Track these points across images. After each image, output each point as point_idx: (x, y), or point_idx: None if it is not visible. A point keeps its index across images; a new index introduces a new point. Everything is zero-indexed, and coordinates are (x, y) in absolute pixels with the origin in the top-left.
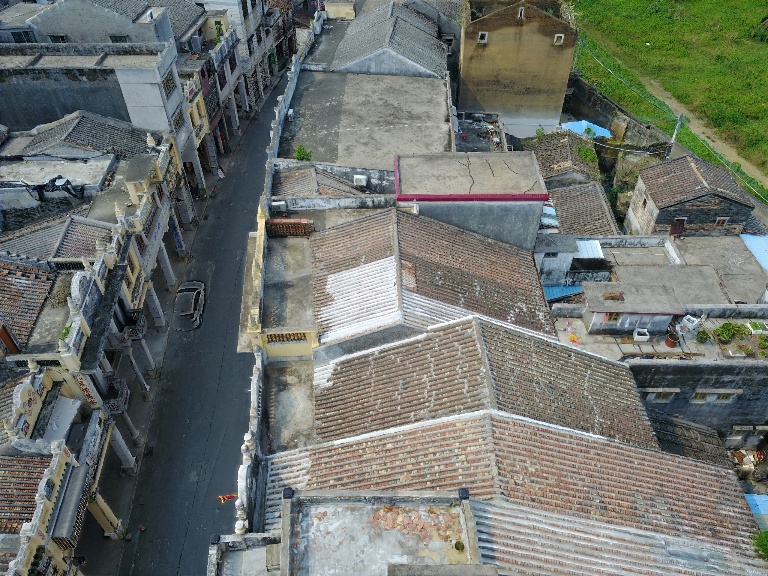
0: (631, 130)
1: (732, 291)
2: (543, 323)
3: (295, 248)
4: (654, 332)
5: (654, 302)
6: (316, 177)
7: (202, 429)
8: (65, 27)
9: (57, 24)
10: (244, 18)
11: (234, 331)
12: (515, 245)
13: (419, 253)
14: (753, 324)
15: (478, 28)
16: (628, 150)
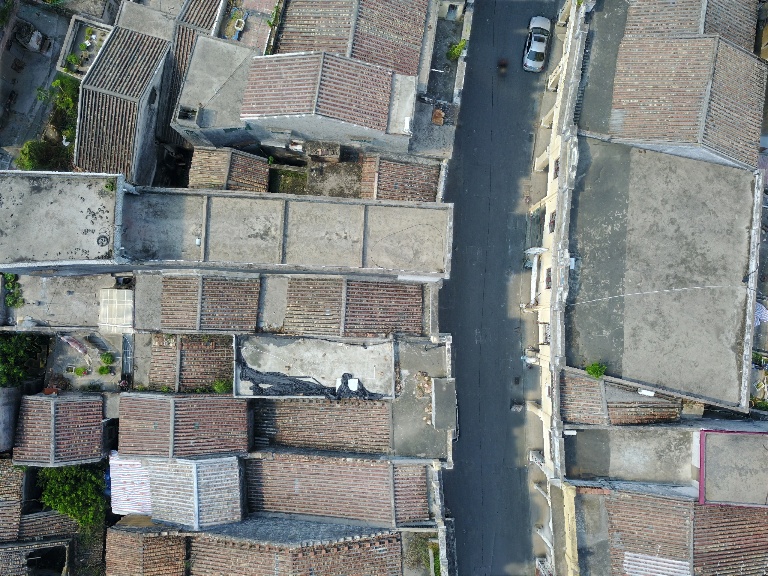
0: None
1: None
2: None
3: (592, 505)
4: None
5: None
6: (605, 395)
7: (477, 539)
8: (292, 126)
9: (282, 124)
10: None
11: (487, 440)
12: None
13: (706, 548)
14: None
15: None
16: None
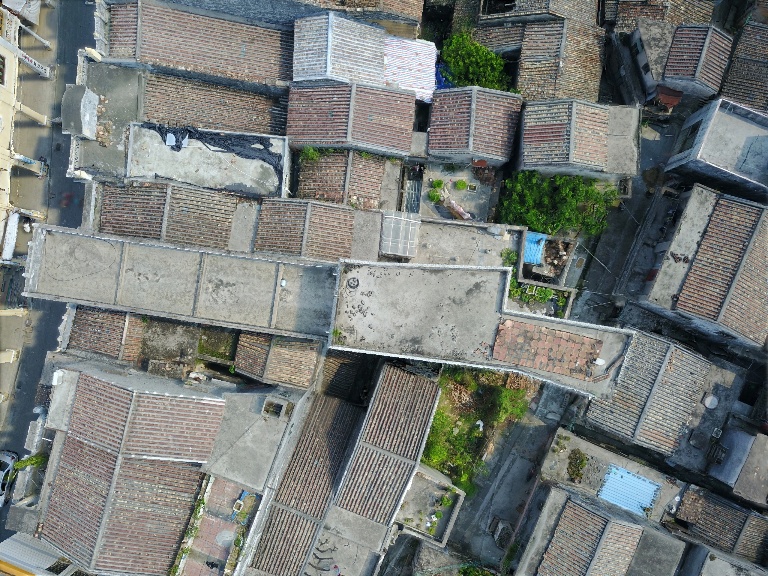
0: None
1: None
2: None
3: None
4: None
5: None
6: None
7: None
8: None
9: None
10: None
11: None
12: None
13: None
14: None
15: None
16: None
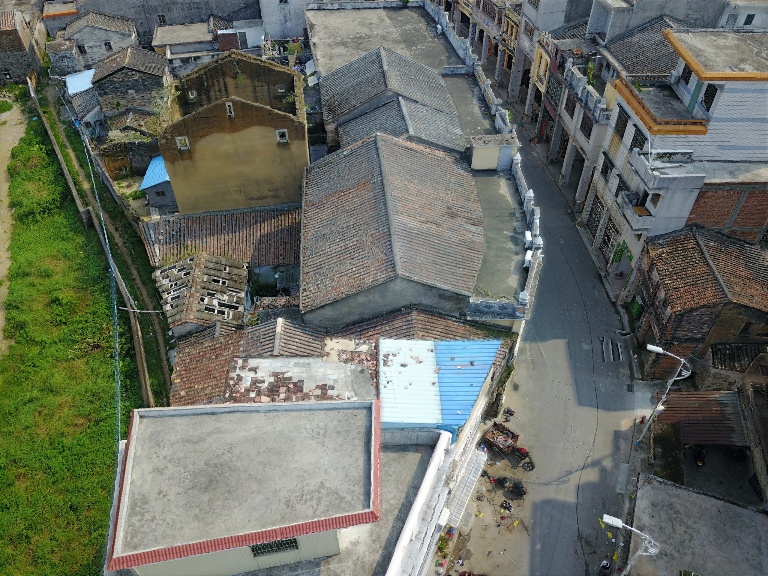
0: None
1: None
2: None
3: None
4: None
5: None
6: None
7: None
8: None
9: None
10: None
11: None
12: None
13: None
14: None
15: None
16: None
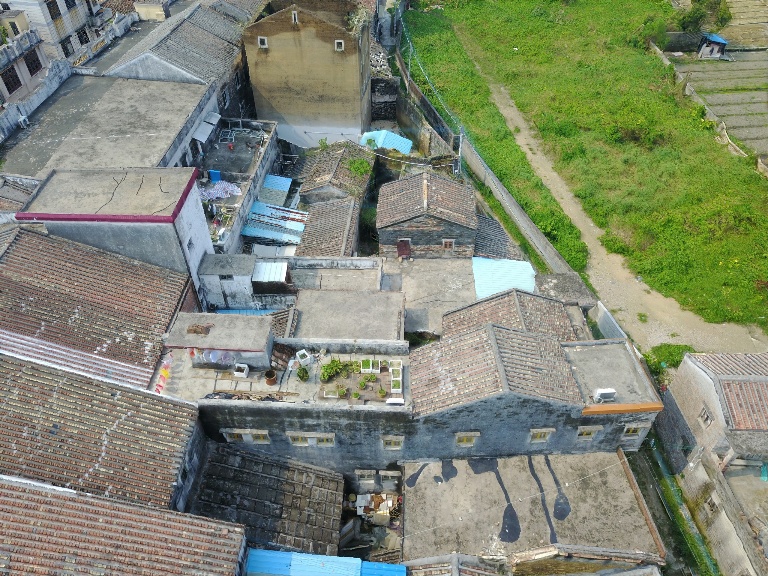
0: (433, 141)
1: (432, 319)
2: (146, 354)
3: None
4: (259, 367)
5: (239, 337)
6: None
7: None
8: None
9: None
10: (53, 19)
11: None
12: (167, 267)
13: (19, 276)
14: (364, 362)
15: (255, 33)
16: (411, 163)
